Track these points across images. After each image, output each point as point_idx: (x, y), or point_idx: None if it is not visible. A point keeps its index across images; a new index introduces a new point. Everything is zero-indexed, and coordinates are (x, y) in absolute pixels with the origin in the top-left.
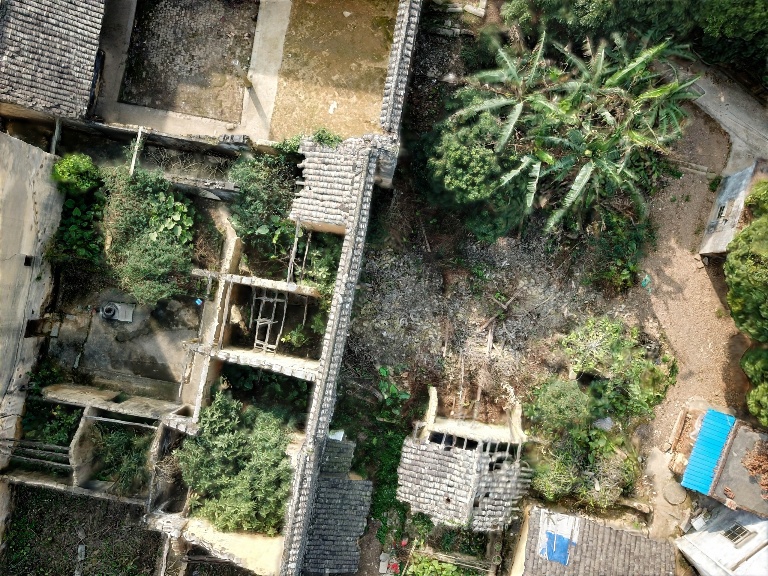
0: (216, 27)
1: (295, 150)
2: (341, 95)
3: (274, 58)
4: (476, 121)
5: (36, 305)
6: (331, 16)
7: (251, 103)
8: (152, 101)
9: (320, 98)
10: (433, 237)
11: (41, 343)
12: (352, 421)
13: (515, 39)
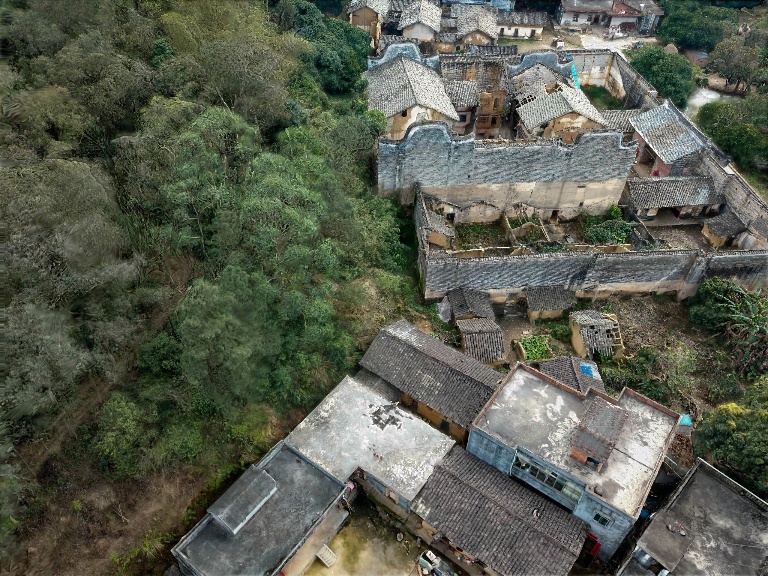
0: None
1: None
2: None
3: None
4: None
5: (563, 213)
6: None
7: None
8: None
9: None
10: (671, 319)
11: (547, 220)
12: (580, 308)
13: None
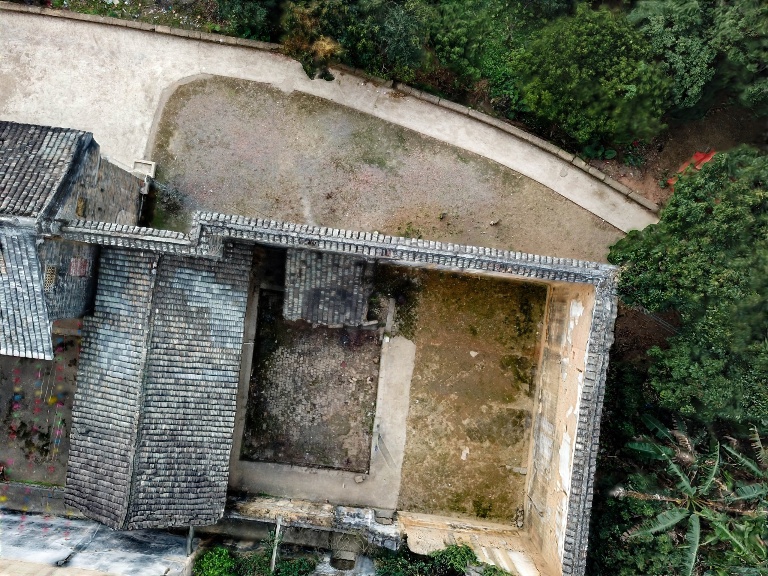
0: (337, 373)
1: (457, 570)
2: (473, 440)
3: (401, 405)
4: (652, 543)
5: None
6: (457, 357)
7: (379, 453)
8: (274, 454)
9: (451, 444)
10: None
11: None
12: None
13: (687, 451)
